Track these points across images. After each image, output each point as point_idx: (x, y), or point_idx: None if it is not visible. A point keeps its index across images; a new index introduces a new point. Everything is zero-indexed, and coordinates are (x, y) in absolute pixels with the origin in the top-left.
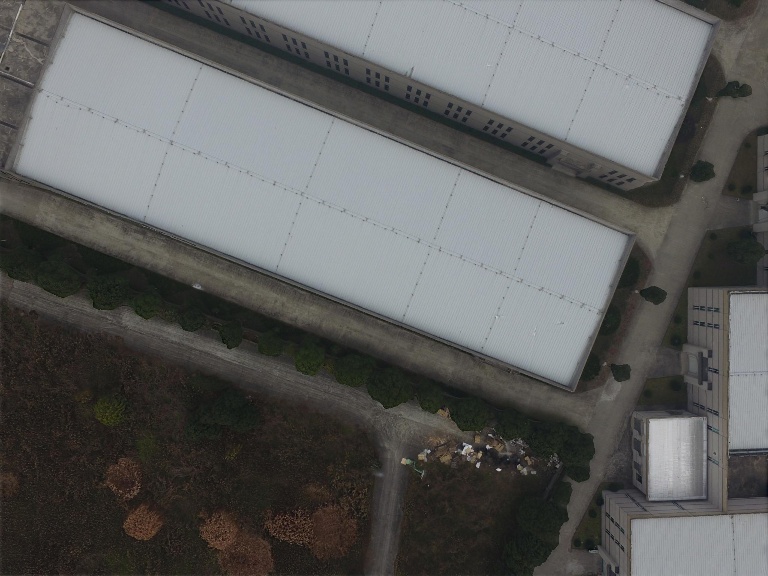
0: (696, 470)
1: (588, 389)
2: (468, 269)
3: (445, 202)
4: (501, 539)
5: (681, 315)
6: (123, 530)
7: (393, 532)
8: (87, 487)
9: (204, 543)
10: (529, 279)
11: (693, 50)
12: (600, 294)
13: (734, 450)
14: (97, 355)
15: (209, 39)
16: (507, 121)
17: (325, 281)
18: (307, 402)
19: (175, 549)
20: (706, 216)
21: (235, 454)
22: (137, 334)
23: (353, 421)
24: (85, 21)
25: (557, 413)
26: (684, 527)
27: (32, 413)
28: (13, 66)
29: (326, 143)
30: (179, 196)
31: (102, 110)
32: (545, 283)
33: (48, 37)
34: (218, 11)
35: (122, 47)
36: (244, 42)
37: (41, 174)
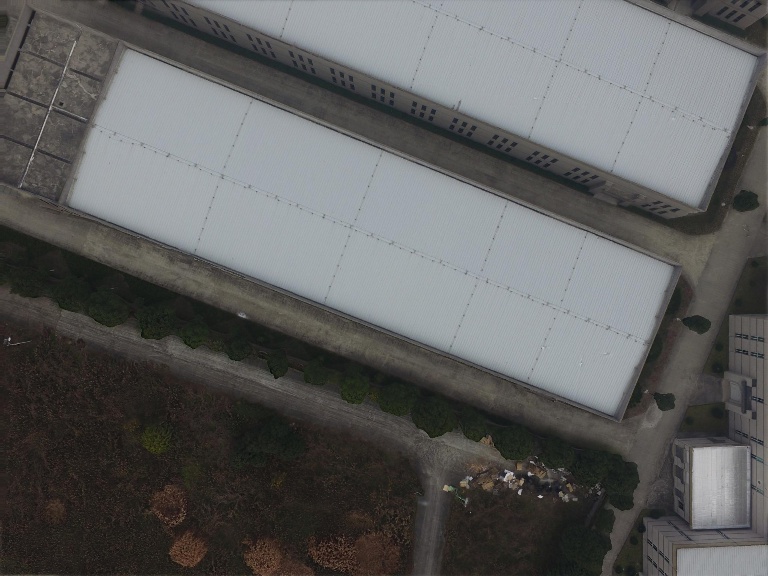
0: (740, 499)
1: (629, 416)
2: (515, 300)
3: (492, 234)
4: (543, 566)
5: (722, 342)
6: (169, 556)
7: (435, 558)
8: (133, 514)
9: (248, 569)
10: (575, 310)
11: (738, 82)
12: (646, 325)
13: None
14: (143, 383)
15: (254, 71)
16: (553, 153)
17: (373, 312)
18: (350, 429)
19: (220, 575)
20: (747, 244)
21: (280, 482)
22: (182, 362)
23: (396, 448)
24: (137, 57)
25: (598, 440)
26: (729, 557)
27: (80, 441)
28: (67, 101)
29: (374, 176)
30: (229, 229)
31: (154, 145)
32: (591, 314)
33: (101, 73)
34: (266, 45)
35: (174, 82)
36: (289, 74)
37: (93, 207)
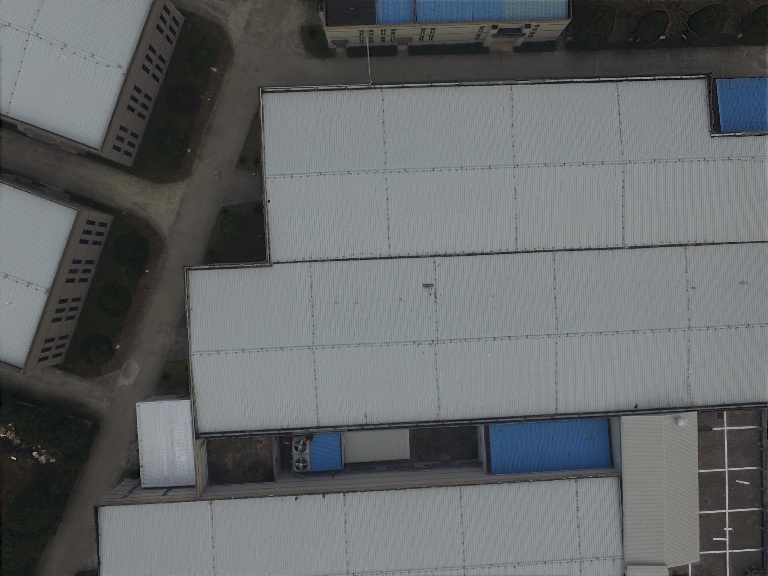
0: (192, 455)
1: (103, 373)
2: None
3: None
4: None
5: None
6: None
7: None
8: None
9: None
10: None
11: (137, 17)
12: (48, 273)
13: (208, 433)
14: None
15: None
16: None
17: None
18: None
19: None
20: (220, 191)
21: None
22: None
23: None
24: None
25: (73, 399)
26: (158, 514)
27: None
28: None
29: None
30: None
31: None
32: None
33: None
34: None
35: None
36: None
37: None
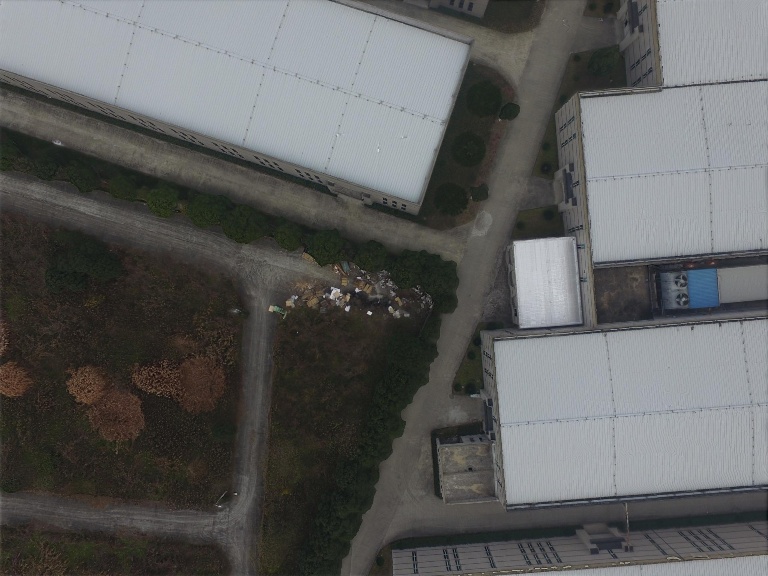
0: (569, 294)
1: (457, 224)
2: (304, 87)
3: (278, 23)
4: (374, 383)
5: (550, 142)
6: None
7: (265, 383)
8: None
9: (73, 399)
10: (367, 93)
11: None
12: (443, 105)
13: (601, 262)
14: None
15: None
16: None
17: (163, 110)
18: (171, 253)
19: (43, 405)
20: (568, 39)
21: (95, 302)
22: (2, 193)
23: (218, 270)
24: None
25: (427, 251)
26: (553, 347)
27: None
28: None
29: None
30: (17, 35)
31: None
32: (384, 96)
33: None
34: None
35: None
36: None
37: None
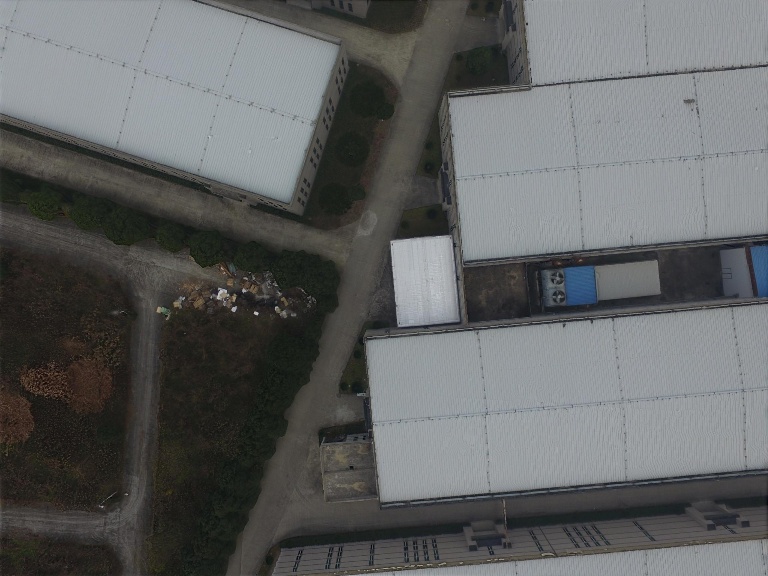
0: (447, 292)
1: (342, 224)
2: (175, 89)
3: (149, 26)
4: None
5: (433, 141)
6: None
7: (154, 384)
8: None
9: None
10: (238, 95)
11: None
12: (313, 105)
13: (472, 261)
14: None
15: None
16: None
17: (38, 114)
18: (59, 255)
19: None
20: (451, 38)
21: None
22: None
23: (106, 272)
24: None
25: (313, 251)
26: (426, 346)
27: None
28: None
29: None
30: None
31: None
32: (255, 98)
33: None
34: None
35: None
36: None
37: None
